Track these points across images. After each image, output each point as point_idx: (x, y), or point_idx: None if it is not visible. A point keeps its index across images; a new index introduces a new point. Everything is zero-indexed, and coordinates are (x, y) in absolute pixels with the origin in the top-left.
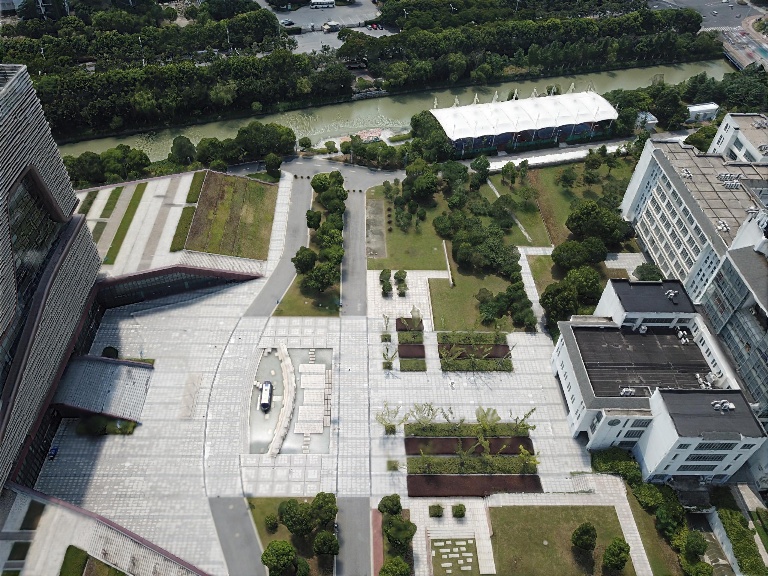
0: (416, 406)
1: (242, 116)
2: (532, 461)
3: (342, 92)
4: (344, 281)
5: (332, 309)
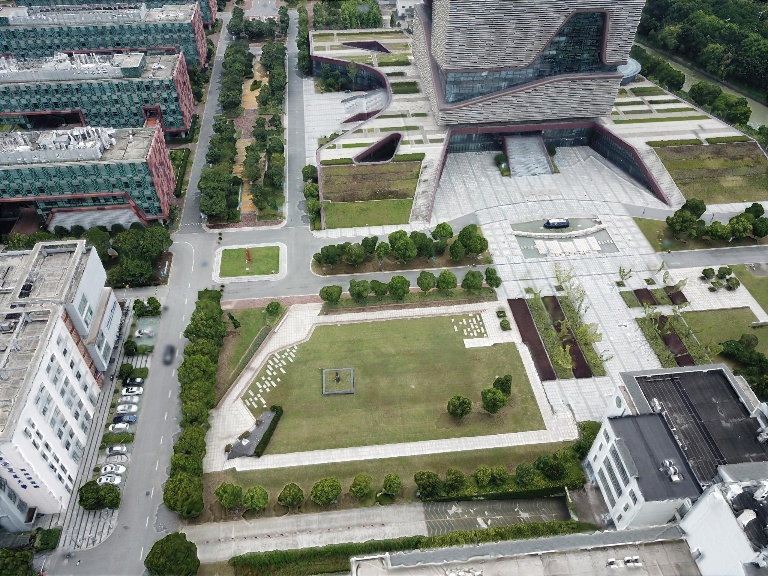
0: (579, 286)
1: None
2: None
3: None
4: (701, 252)
5: (661, 247)
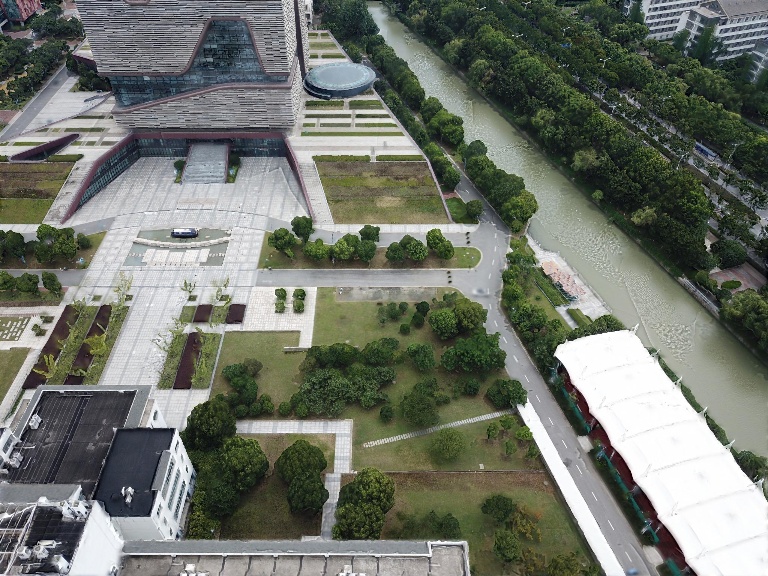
0: None
1: (587, 194)
2: (43, 371)
3: (684, 265)
4: (303, 271)
5: (266, 263)
